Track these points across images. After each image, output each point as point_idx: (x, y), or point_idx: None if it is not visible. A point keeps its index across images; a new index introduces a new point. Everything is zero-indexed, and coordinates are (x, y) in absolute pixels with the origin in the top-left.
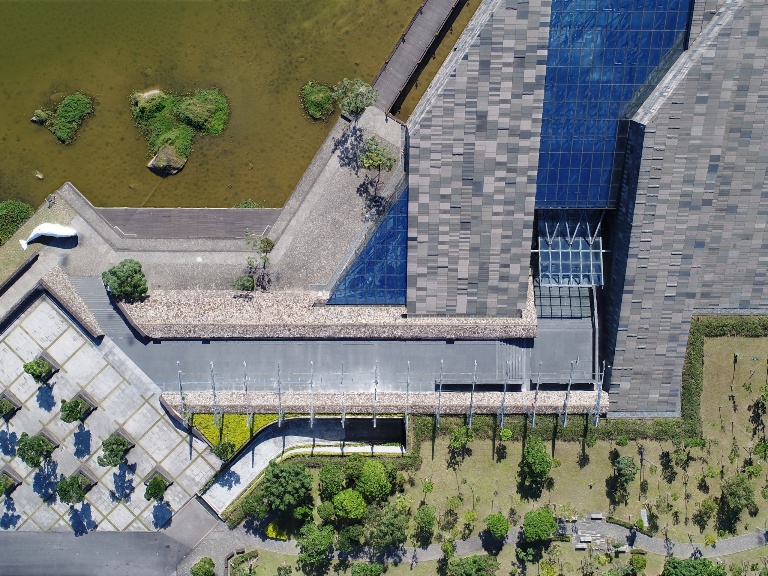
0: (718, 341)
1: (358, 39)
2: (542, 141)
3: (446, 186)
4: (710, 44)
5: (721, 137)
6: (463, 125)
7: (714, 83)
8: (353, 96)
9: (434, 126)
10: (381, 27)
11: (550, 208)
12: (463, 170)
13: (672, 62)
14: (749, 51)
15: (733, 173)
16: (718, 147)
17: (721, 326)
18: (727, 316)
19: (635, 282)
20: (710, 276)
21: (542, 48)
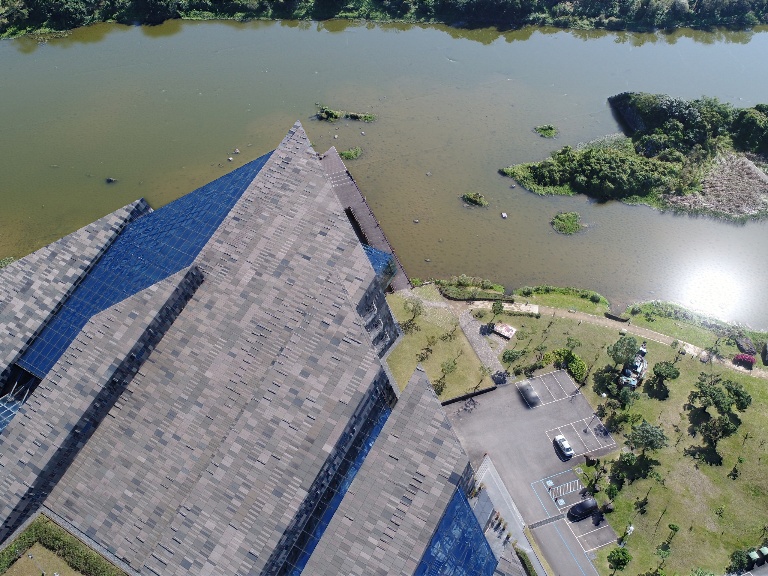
0: (44, 552)
1: None
2: (53, 319)
3: None
4: None
5: (130, 347)
6: (16, 284)
7: (146, 308)
8: (2, 263)
9: (2, 277)
10: None
11: (24, 368)
12: None
13: None
14: (201, 317)
15: (146, 402)
16: (124, 354)
17: (56, 538)
18: (70, 535)
19: (10, 435)
20: (83, 486)
21: (89, 260)
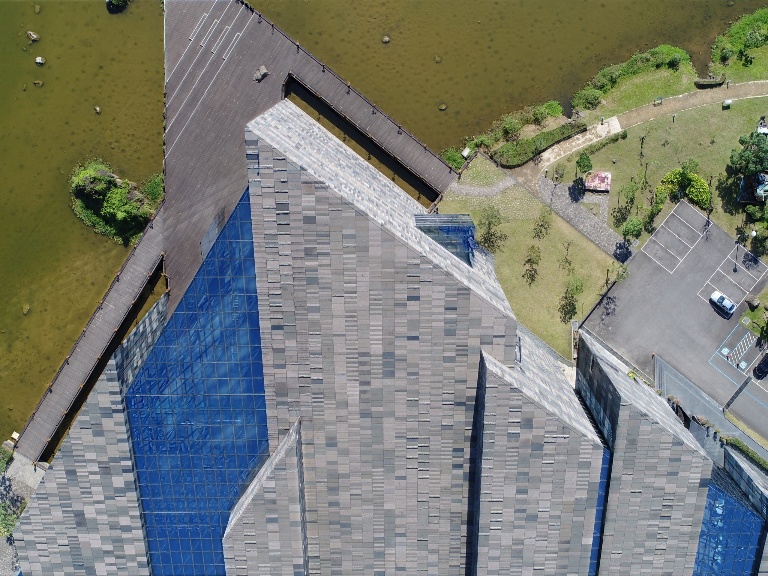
0: None
1: (11, 384)
2: (148, 530)
3: (59, 570)
4: (268, 476)
5: (300, 549)
6: (62, 522)
7: (281, 507)
8: None
9: (34, 523)
10: (34, 372)
11: None
12: (72, 558)
13: (263, 463)
14: (331, 459)
15: (341, 556)
16: (299, 557)
17: None
18: None
19: None
20: None
21: (125, 459)
